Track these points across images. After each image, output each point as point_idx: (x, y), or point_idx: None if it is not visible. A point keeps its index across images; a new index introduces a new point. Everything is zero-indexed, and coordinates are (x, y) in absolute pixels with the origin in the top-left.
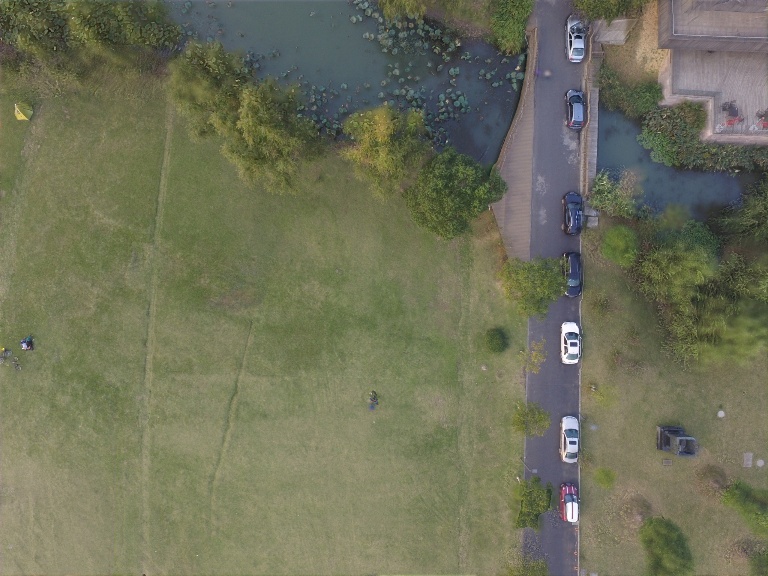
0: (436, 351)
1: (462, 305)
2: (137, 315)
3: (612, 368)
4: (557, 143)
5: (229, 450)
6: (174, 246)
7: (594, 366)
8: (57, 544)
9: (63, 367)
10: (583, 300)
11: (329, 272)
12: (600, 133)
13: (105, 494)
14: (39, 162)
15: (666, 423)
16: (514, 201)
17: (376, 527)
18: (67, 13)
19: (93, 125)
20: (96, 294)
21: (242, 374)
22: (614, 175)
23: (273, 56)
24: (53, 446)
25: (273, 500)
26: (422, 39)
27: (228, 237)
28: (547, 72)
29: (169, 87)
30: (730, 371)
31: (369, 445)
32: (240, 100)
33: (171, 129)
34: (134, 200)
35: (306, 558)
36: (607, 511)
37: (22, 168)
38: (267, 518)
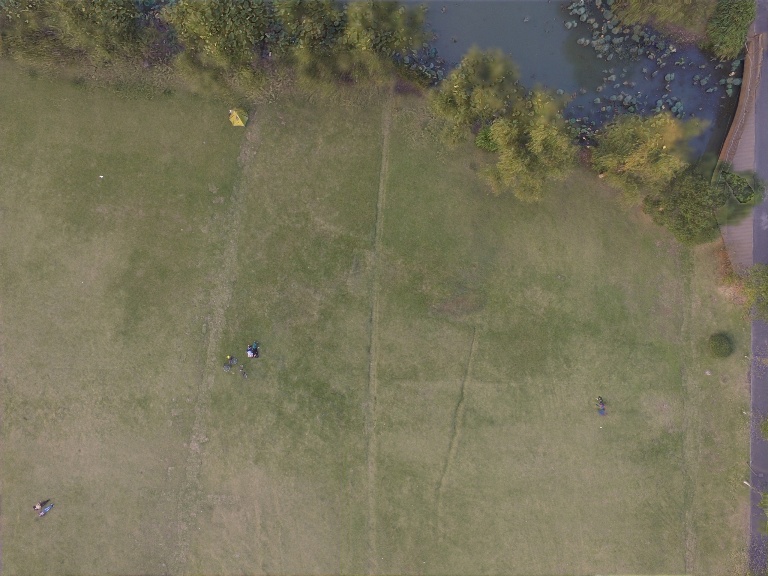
0: (659, 356)
1: (684, 310)
2: (360, 322)
3: None
4: None
5: (456, 457)
6: (395, 252)
7: None
8: (284, 552)
9: (289, 374)
10: None
11: (551, 278)
12: None
13: (331, 501)
14: (256, 168)
15: None
16: (737, 207)
17: (604, 532)
18: (283, 18)
19: (309, 131)
20: (319, 301)
21: (468, 380)
22: None
23: (487, 62)
24: (280, 454)
25: (501, 506)
26: (638, 45)
27: (448, 243)
28: (767, 78)
29: (386, 93)
30: None
31: (597, 451)
32: (457, 106)
33: (388, 135)
34: (354, 206)
35: (534, 564)
36: None
37: (239, 174)
38: (495, 524)
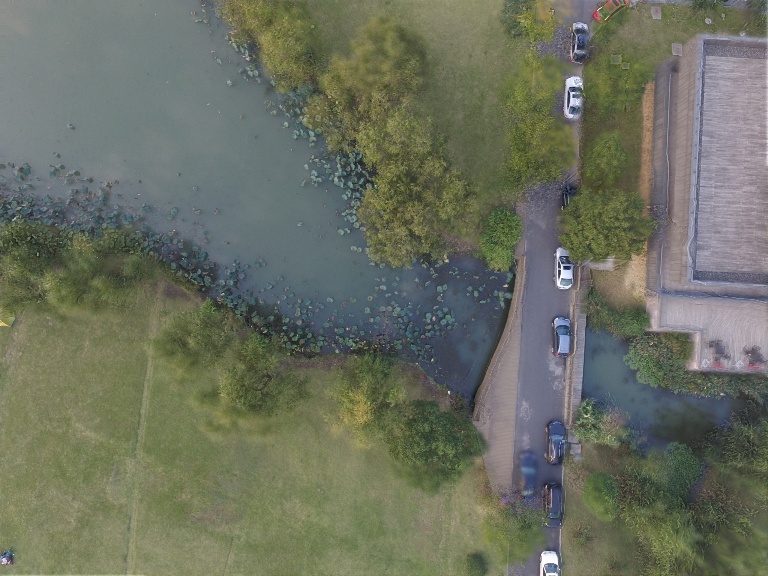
0: (416, 573)
1: (443, 527)
2: (118, 530)
3: None
4: (543, 368)
5: None
6: (156, 461)
7: None
8: None
9: None
10: (563, 528)
11: (311, 491)
12: (586, 358)
13: None
14: (21, 370)
15: None
16: (498, 427)
17: None
18: (50, 220)
19: (76, 333)
20: (77, 508)
21: None
22: (598, 408)
23: (259, 266)
24: None
25: None
26: (410, 254)
27: (210, 452)
28: (535, 296)
29: (153, 297)
30: None
31: None
32: (225, 312)
33: (155, 339)
34: (116, 413)
35: None
36: None
37: (3, 376)
38: None
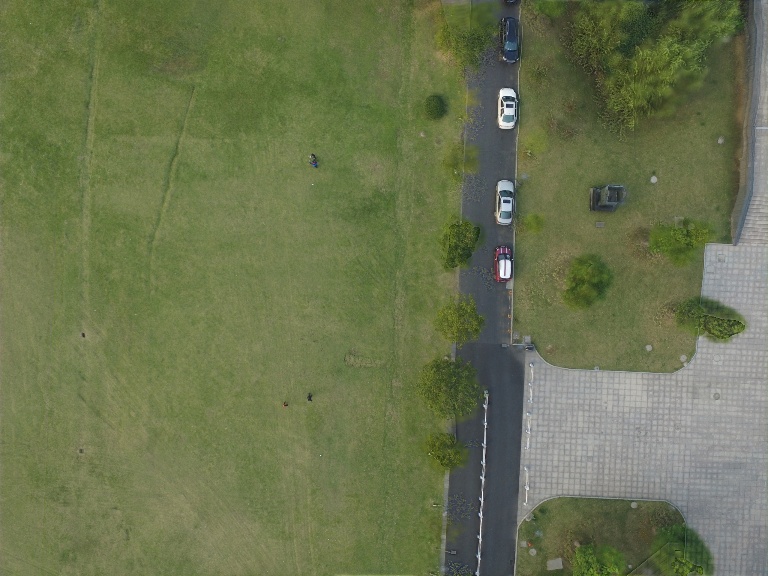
0: (376, 118)
1: (403, 74)
2: (80, 77)
3: (548, 133)
4: None
5: (169, 210)
6: (118, 11)
7: (531, 132)
8: None
9: (5, 126)
10: (521, 68)
11: (272, 39)
12: None
13: (45, 253)
14: None
15: (599, 184)
16: None
17: (313, 288)
18: None
19: None
20: (39, 56)
21: (183, 136)
22: None
23: None
24: None
25: (212, 260)
26: None
27: (172, 4)
28: None
29: None
30: (664, 140)
31: (307, 207)
32: None
33: None
34: None
35: (243, 317)
36: (540, 273)
37: None
38: (205, 278)
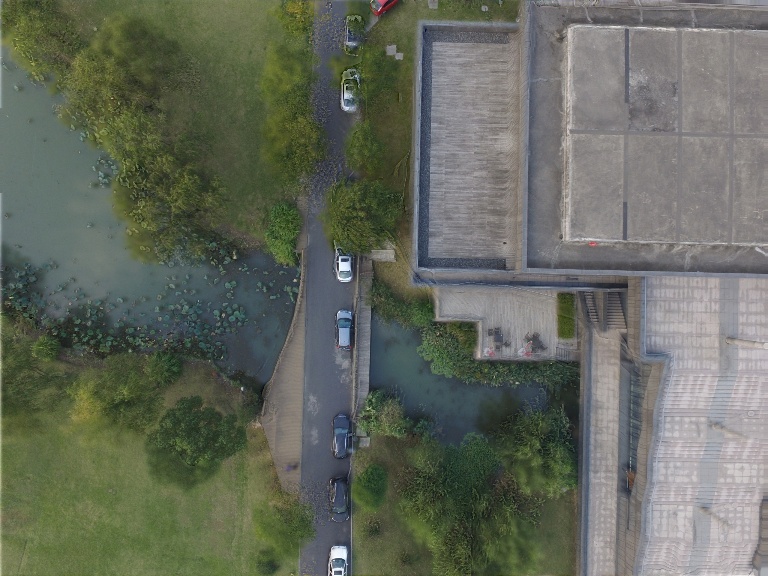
0: (209, 571)
1: (236, 524)
2: None
3: None
4: (329, 362)
5: None
6: None
7: None
8: None
9: None
10: (353, 523)
11: (103, 492)
12: (374, 350)
13: None
14: None
15: None
16: (284, 422)
17: None
18: None
19: None
20: None
21: None
22: (381, 400)
23: (50, 268)
24: None
25: None
26: (198, 252)
27: (3, 455)
28: (319, 290)
29: None
30: None
31: None
32: (15, 316)
33: None
34: None
35: None
36: None
37: None
38: None
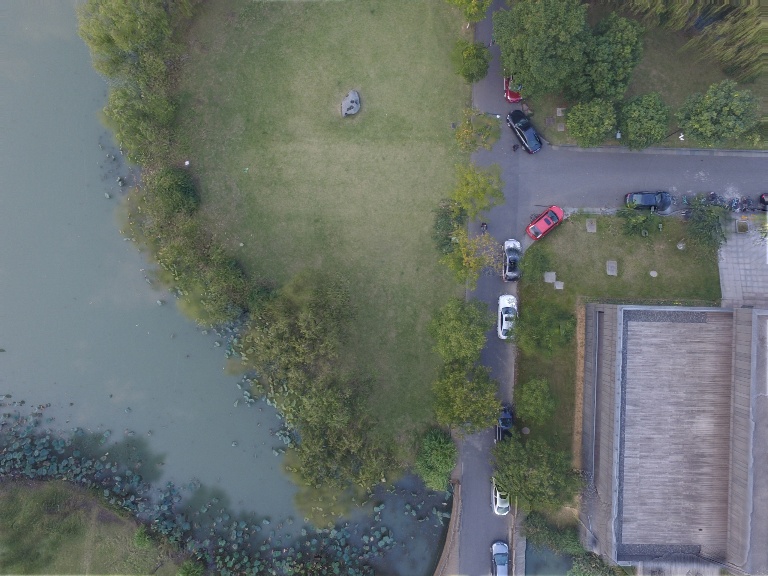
0: None
1: None
2: None
3: None
4: None
5: None
6: None
7: None
8: None
9: None
10: None
11: None
12: None
13: None
14: None
15: None
16: None
17: None
18: None
19: (12, 559)
20: None
21: None
22: None
23: (194, 487)
24: None
25: None
26: None
27: None
28: (473, 520)
29: (88, 523)
30: None
31: None
32: (160, 538)
33: (90, 565)
34: None
35: None
36: None
37: None
38: None
